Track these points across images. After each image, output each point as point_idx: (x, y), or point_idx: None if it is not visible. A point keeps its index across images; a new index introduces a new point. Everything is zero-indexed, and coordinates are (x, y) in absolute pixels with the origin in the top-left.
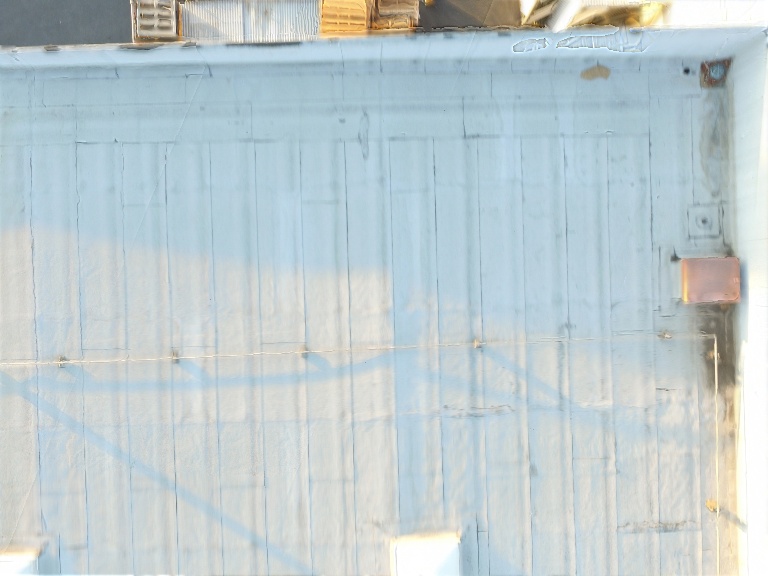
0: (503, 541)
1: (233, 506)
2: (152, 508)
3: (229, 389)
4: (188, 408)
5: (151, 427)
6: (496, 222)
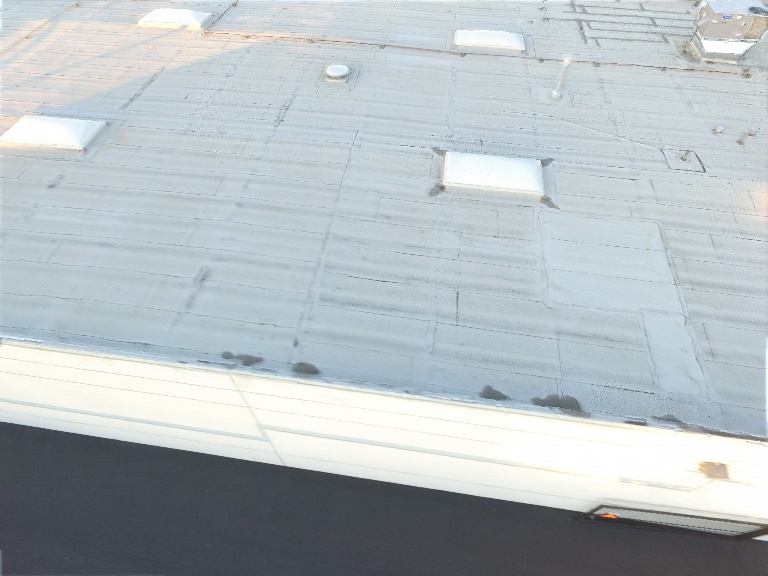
0: (167, 7)
1: (74, 60)
2: (47, 82)
3: (15, 56)
4: (8, 67)
5: (3, 78)
6: (31, 0)
